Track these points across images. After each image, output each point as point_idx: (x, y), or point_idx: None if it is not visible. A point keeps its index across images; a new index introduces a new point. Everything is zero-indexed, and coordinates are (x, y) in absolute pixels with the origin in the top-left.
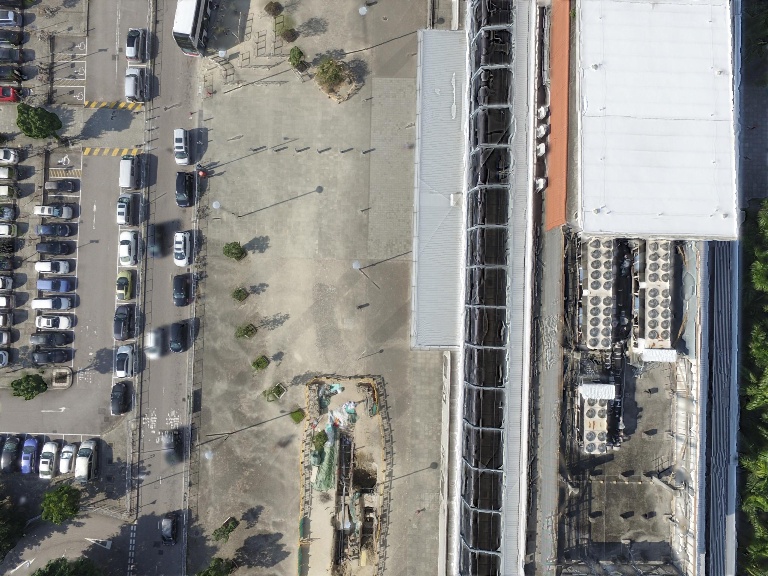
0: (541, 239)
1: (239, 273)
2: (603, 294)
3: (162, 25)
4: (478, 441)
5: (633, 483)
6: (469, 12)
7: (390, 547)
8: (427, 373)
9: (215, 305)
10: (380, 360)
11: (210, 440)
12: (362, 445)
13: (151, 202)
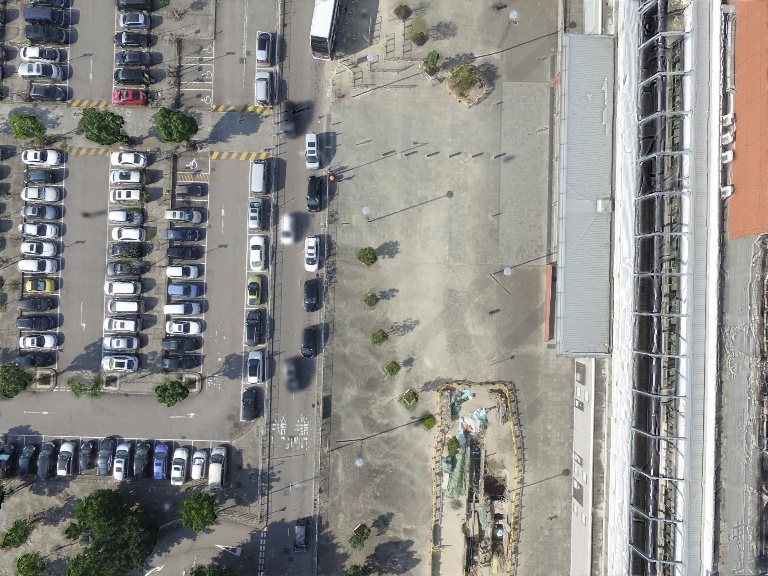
0: (723, 247)
1: (369, 278)
2: None
3: (290, 28)
4: None
5: None
6: (625, 17)
7: (522, 554)
8: (559, 379)
9: (345, 310)
10: (511, 366)
11: (340, 446)
12: (493, 452)
13: (280, 207)
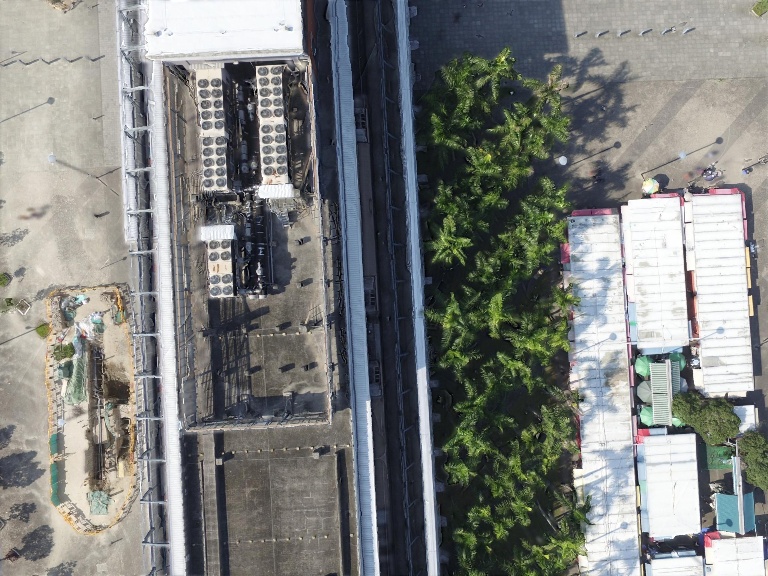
0: (180, 96)
1: None
2: (216, 134)
3: None
4: None
5: (291, 334)
6: None
7: None
8: None
9: None
10: (124, 268)
11: None
12: (111, 355)
13: None
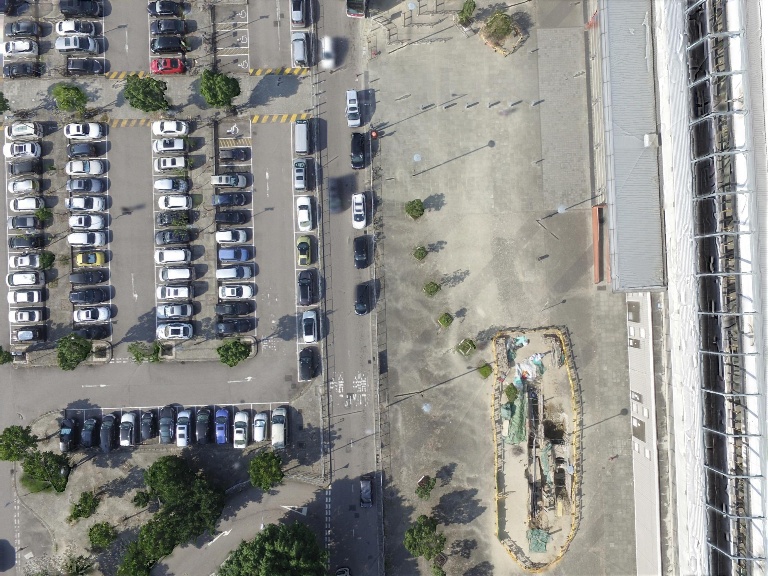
0: None
1: (416, 232)
2: None
3: None
4: (694, 377)
5: None
6: None
7: (585, 496)
8: (611, 320)
9: (394, 265)
10: (563, 310)
11: (399, 400)
12: (551, 396)
13: (323, 166)
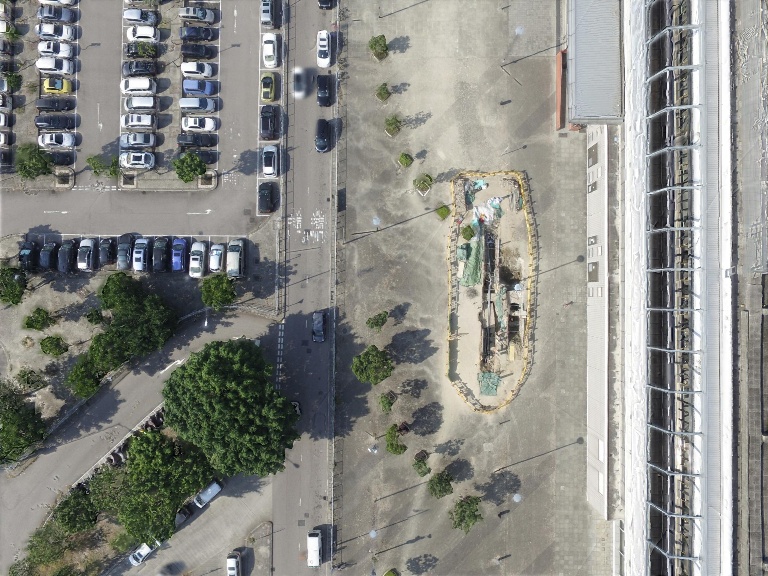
0: None
1: (380, 73)
2: None
3: None
4: None
5: None
6: None
7: (538, 341)
8: (571, 167)
9: (357, 106)
10: (523, 156)
11: (356, 238)
12: (508, 240)
13: (291, 6)
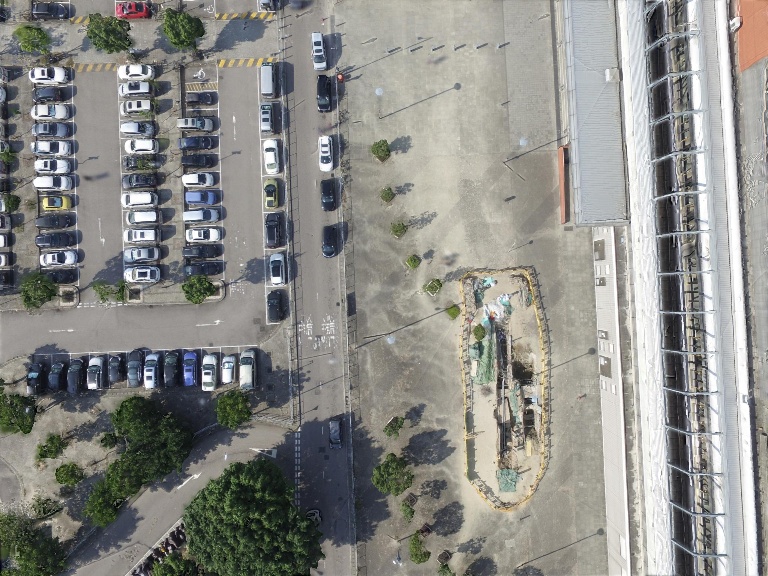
0: (736, 80)
1: (383, 175)
2: None
3: None
4: None
5: None
6: None
7: (554, 435)
8: (578, 260)
9: (362, 208)
10: (530, 251)
11: (367, 342)
12: (519, 336)
13: (290, 110)
